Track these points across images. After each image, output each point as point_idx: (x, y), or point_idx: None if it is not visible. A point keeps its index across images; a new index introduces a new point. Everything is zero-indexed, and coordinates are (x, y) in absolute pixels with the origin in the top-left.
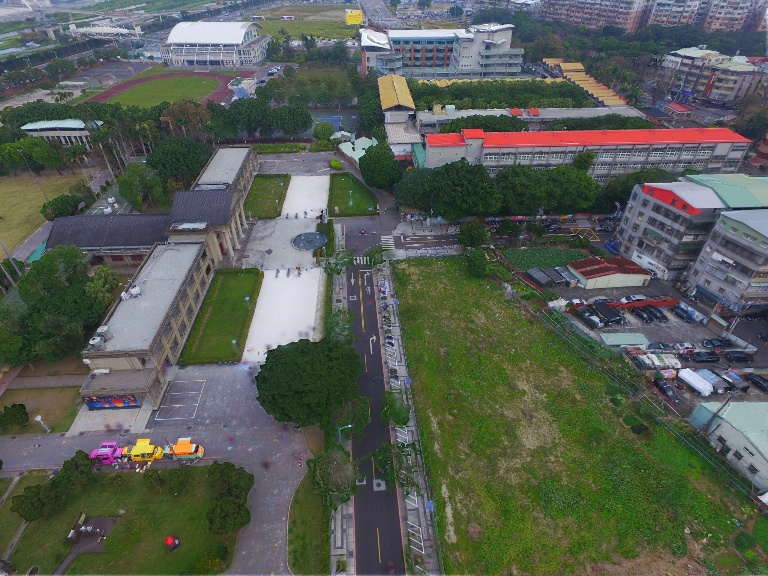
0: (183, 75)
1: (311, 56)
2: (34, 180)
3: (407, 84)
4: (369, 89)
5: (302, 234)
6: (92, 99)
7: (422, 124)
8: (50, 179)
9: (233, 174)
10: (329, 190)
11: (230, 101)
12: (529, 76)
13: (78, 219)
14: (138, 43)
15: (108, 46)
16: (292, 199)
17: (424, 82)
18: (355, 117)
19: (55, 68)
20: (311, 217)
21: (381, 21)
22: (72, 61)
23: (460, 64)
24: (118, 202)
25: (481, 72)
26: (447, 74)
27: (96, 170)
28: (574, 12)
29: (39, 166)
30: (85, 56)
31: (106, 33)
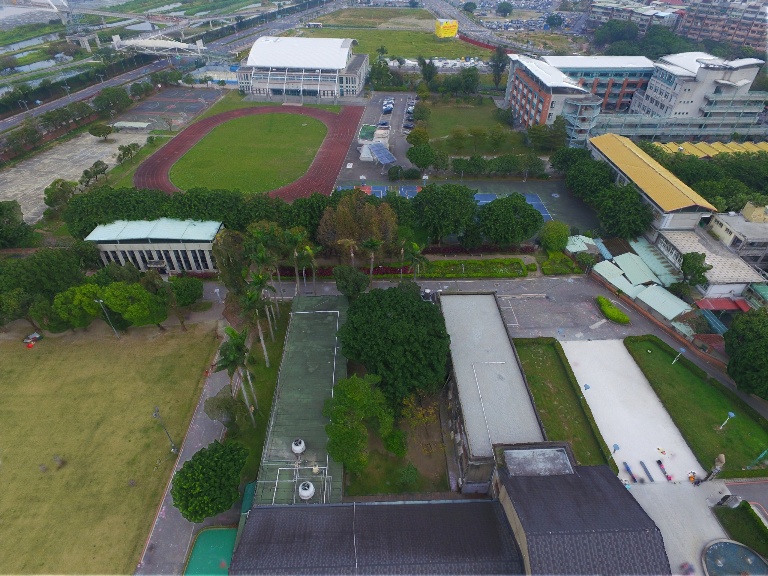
0: (271, 111)
1: (434, 87)
2: (119, 344)
3: (646, 152)
4: (579, 155)
5: (708, 548)
6: (163, 152)
7: (746, 243)
8: (146, 341)
9: (515, 380)
10: (658, 390)
11: (357, 159)
12: (766, 129)
13: (282, 572)
14: (199, 60)
15: (159, 62)
16: (600, 412)
17: (679, 152)
18: (559, 196)
19: (106, 101)
20: (677, 476)
21: (470, 32)
22: (121, 86)
23: (673, 111)
24: (309, 447)
25: (702, 123)
26: (655, 125)
27: (217, 317)
28: (734, 29)
29: (129, 322)
30: (135, 78)
31: (159, 47)
